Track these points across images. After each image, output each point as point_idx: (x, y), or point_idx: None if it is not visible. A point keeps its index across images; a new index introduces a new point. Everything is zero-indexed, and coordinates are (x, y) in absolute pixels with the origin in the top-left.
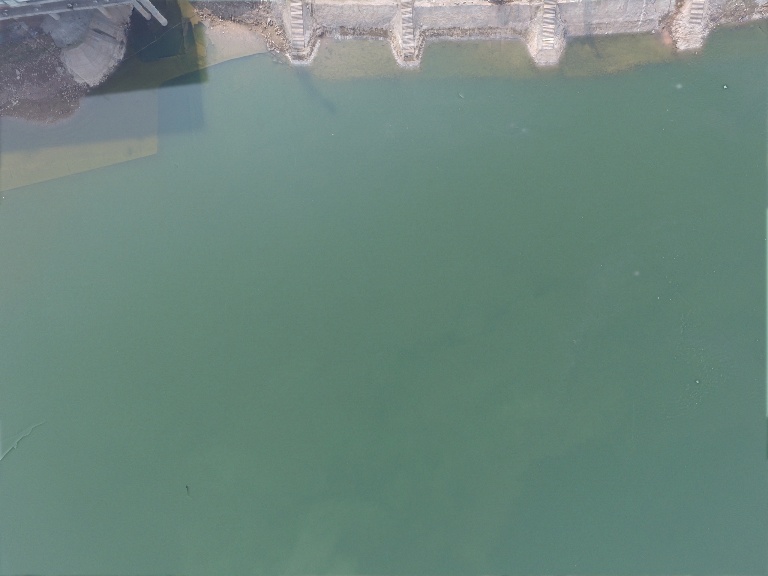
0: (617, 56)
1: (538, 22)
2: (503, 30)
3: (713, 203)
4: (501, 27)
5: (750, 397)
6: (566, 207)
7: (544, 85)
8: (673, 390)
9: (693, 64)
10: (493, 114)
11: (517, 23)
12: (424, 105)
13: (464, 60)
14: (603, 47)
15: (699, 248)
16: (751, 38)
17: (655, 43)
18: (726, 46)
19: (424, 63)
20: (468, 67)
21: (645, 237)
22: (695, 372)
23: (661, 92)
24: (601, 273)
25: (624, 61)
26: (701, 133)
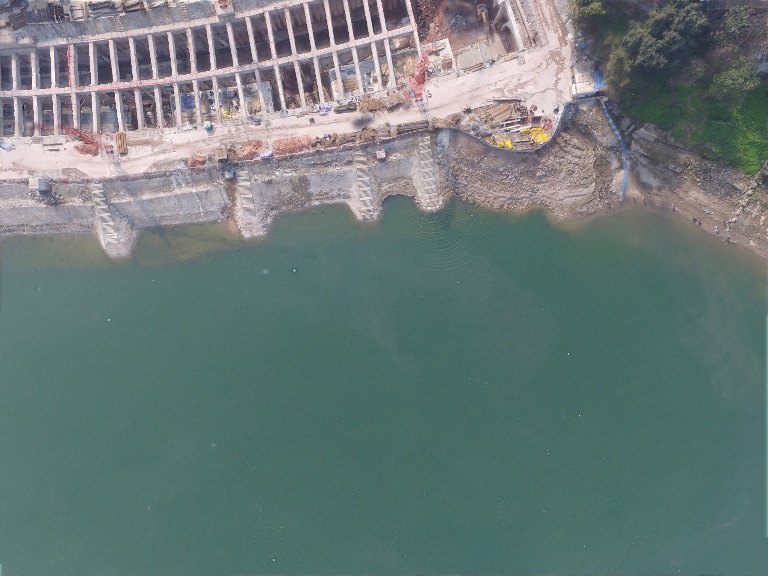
0: (187, 245)
1: (98, 219)
2: (71, 225)
3: (284, 386)
4: (68, 223)
5: (325, 572)
6: (146, 394)
7: (120, 275)
8: (252, 569)
9: (260, 250)
10: (70, 306)
11: (81, 219)
12: (3, 299)
13: (41, 253)
14: (173, 236)
15: (274, 429)
16: (315, 223)
17: (222, 231)
18: (289, 233)
19: (1, 257)
20: (45, 260)
21: (223, 420)
22: (272, 550)
23: (227, 280)
24: (181, 458)
25: (194, 250)
26: (270, 318)
